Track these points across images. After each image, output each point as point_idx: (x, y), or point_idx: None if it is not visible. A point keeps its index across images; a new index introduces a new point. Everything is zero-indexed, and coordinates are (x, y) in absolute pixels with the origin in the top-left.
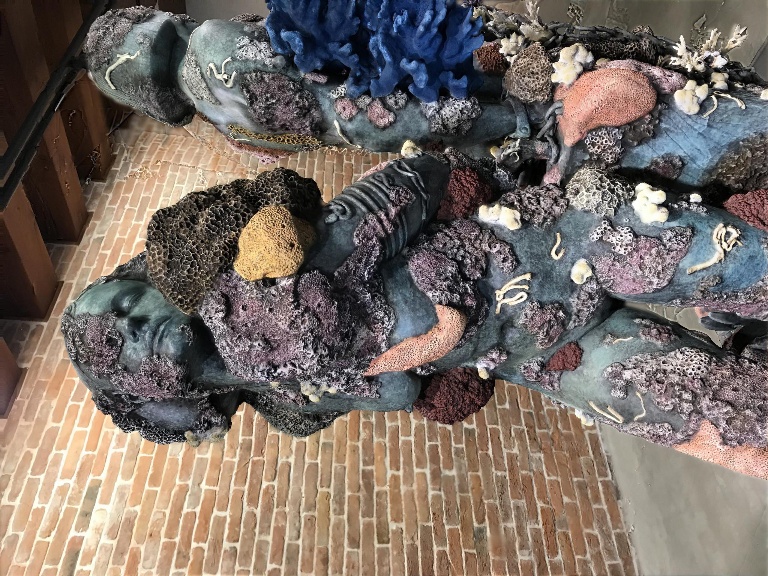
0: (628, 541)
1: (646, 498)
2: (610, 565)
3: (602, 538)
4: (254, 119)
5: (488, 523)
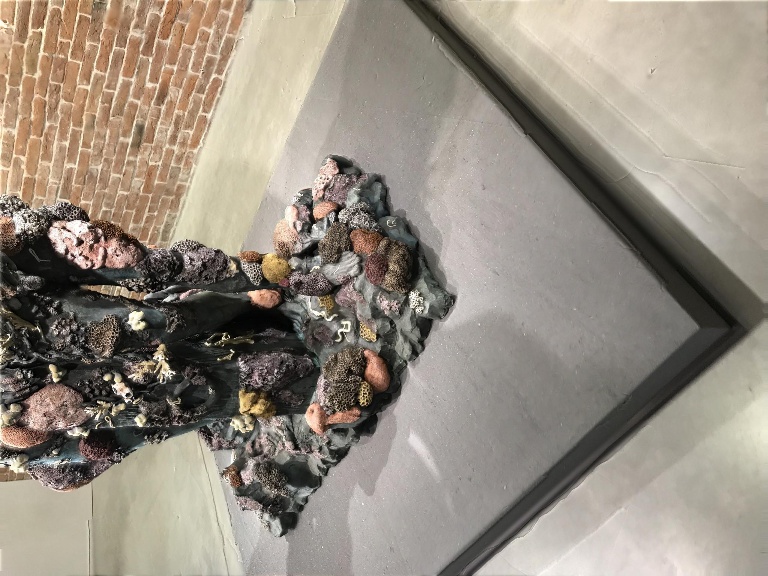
0: (234, 45)
1: (255, 46)
2: (209, 56)
3: (213, 37)
4: None
5: (110, 1)
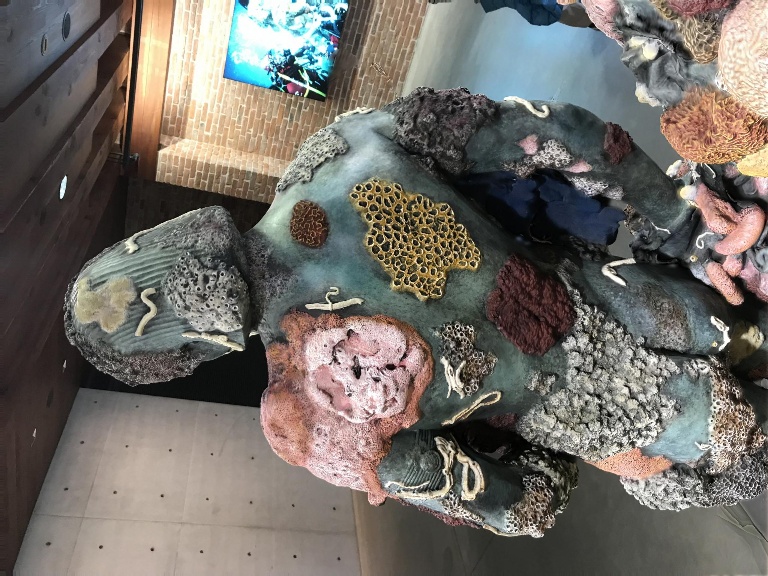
0: None
1: None
2: None
3: None
4: (408, 112)
5: None
